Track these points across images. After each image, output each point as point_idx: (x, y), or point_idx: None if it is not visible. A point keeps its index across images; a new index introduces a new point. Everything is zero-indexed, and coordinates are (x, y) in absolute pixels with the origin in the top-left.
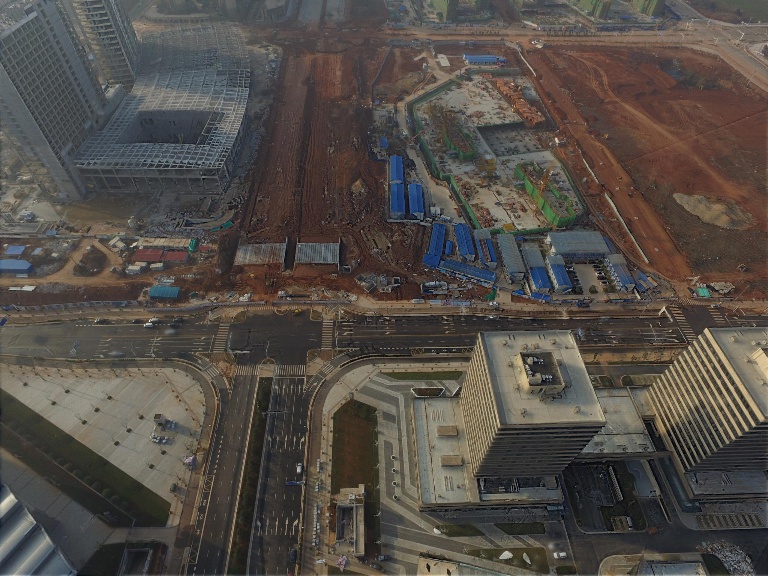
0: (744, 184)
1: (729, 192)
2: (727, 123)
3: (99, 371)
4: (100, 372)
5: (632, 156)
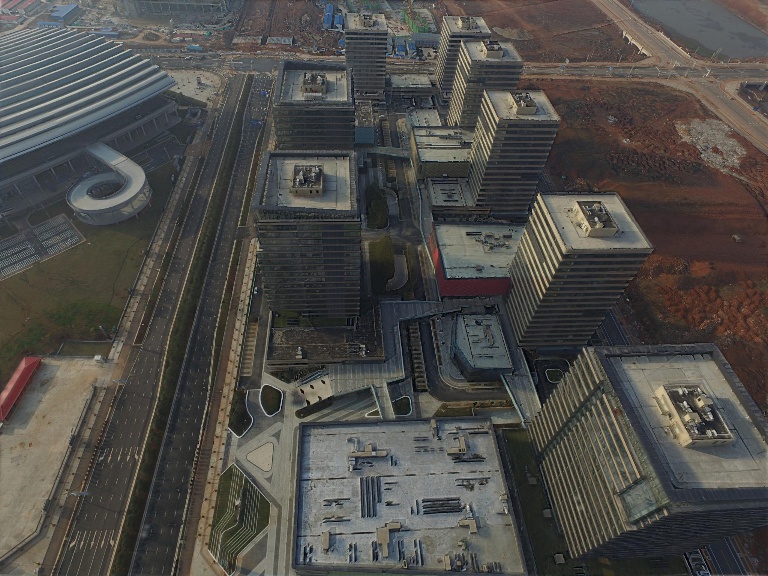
0: (537, 25)
1: (526, 28)
2: (544, 2)
3: (164, 70)
4: None
5: (477, 13)
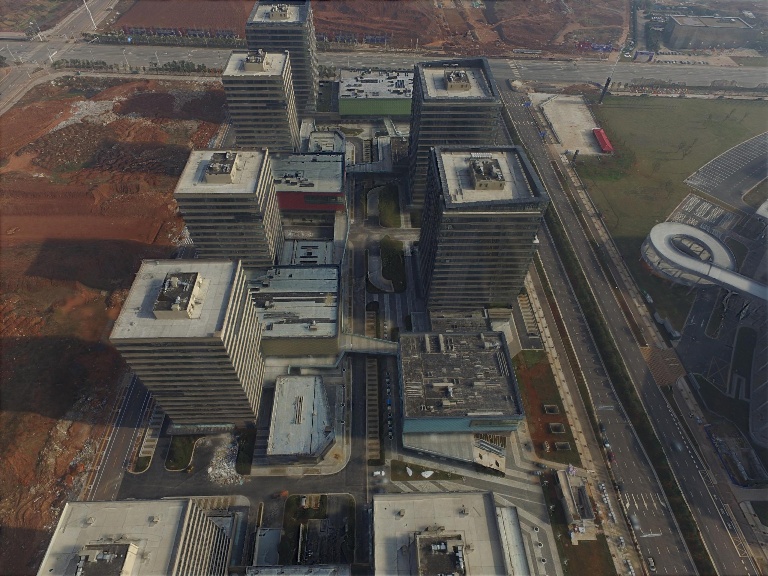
0: None
1: None
2: None
3: None
4: None
5: None
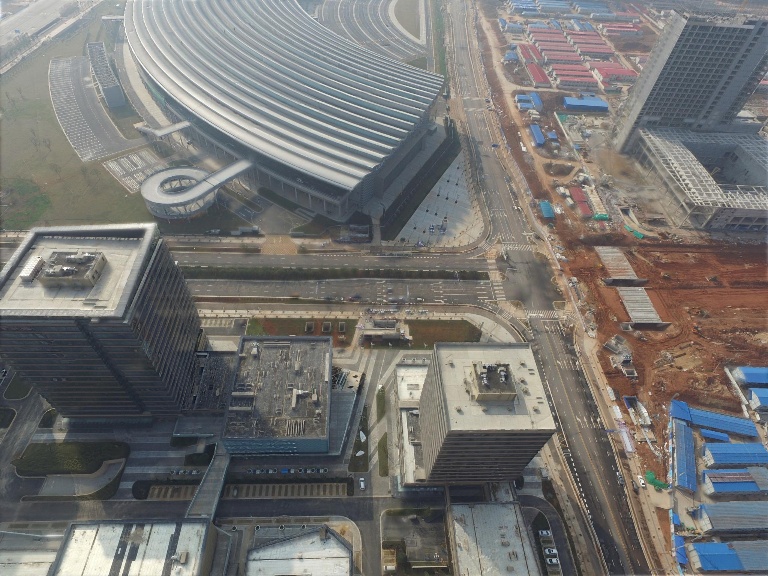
0: None
1: None
2: None
3: (474, 194)
4: (473, 194)
5: None
